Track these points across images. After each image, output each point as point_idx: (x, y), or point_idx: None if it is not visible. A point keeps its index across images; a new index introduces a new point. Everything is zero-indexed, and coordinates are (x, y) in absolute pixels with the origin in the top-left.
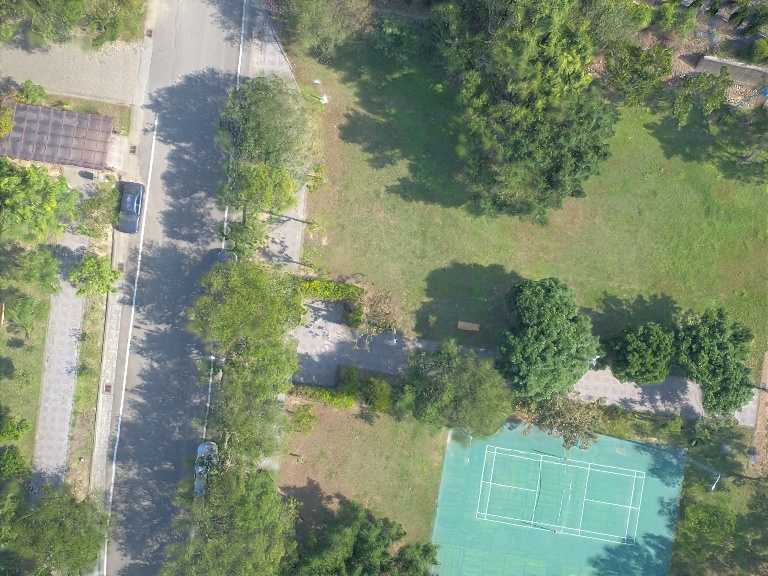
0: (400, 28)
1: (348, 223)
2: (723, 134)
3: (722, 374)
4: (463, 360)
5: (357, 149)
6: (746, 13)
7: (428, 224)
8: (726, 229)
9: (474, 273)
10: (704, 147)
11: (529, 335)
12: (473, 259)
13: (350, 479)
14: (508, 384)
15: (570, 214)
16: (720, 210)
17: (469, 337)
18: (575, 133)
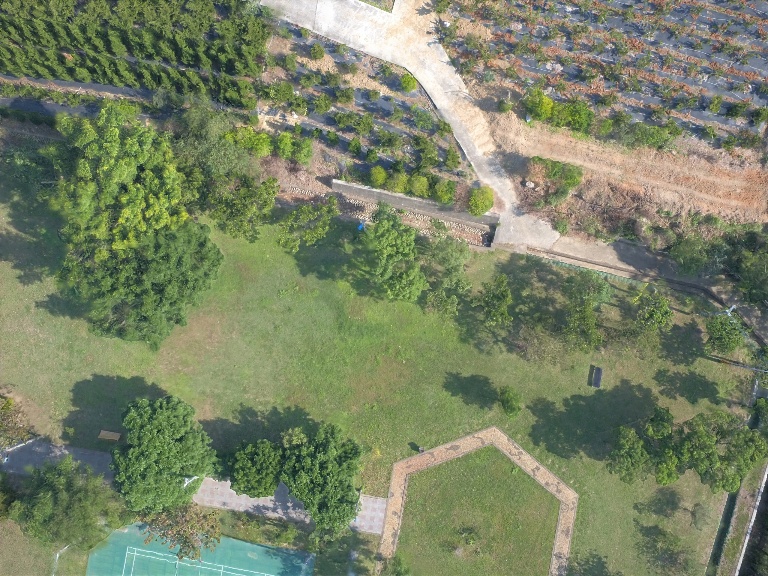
0: (33, 158)
1: (1, 336)
2: (358, 252)
3: (319, 493)
4: (74, 476)
5: (10, 267)
6: (355, 144)
7: (75, 338)
8: (359, 344)
9: (117, 385)
10: (339, 265)
11: (129, 456)
12: (116, 371)
13: (1, 575)
14: (120, 498)
15: (209, 329)
16: (352, 326)
17: (112, 445)
18: (156, 272)
